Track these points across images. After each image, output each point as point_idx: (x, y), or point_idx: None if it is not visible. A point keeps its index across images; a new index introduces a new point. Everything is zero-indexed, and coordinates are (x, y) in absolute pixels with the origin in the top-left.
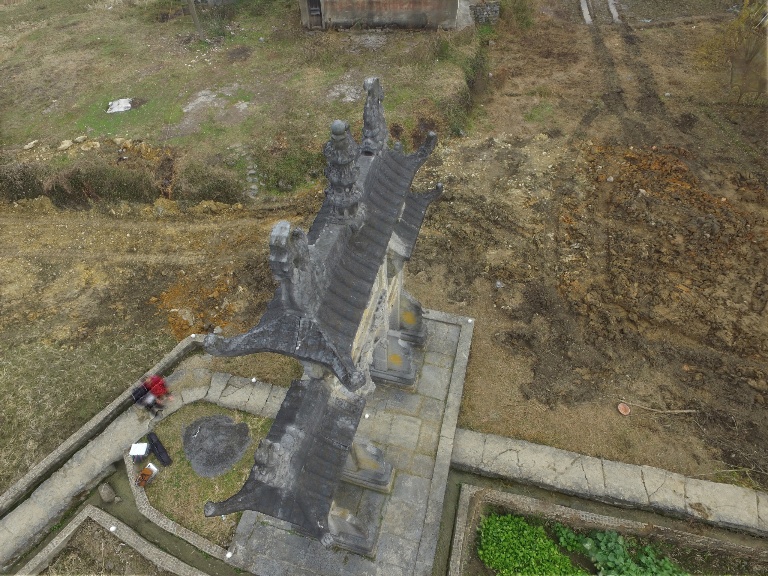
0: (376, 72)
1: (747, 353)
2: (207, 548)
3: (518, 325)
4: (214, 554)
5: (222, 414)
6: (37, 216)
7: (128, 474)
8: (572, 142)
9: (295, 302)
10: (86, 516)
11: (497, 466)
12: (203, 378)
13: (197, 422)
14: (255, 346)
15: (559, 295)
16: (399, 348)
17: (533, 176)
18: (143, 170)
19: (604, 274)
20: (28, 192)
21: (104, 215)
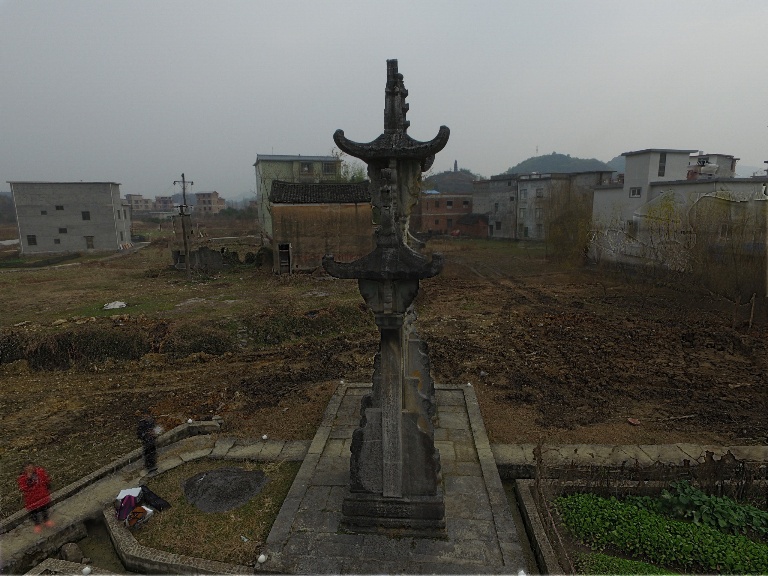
0: (339, 287)
1: (706, 386)
2: (226, 569)
3: (512, 391)
4: (237, 573)
5: (230, 466)
6: (6, 377)
7: (109, 524)
8: (502, 315)
9: (394, 111)
10: (44, 569)
11: (543, 461)
12: (205, 444)
13: (201, 472)
14: (364, 148)
15: (537, 377)
16: (419, 359)
17: (481, 329)
18: (137, 332)
19: (566, 365)
20: (5, 357)
21: (83, 372)
